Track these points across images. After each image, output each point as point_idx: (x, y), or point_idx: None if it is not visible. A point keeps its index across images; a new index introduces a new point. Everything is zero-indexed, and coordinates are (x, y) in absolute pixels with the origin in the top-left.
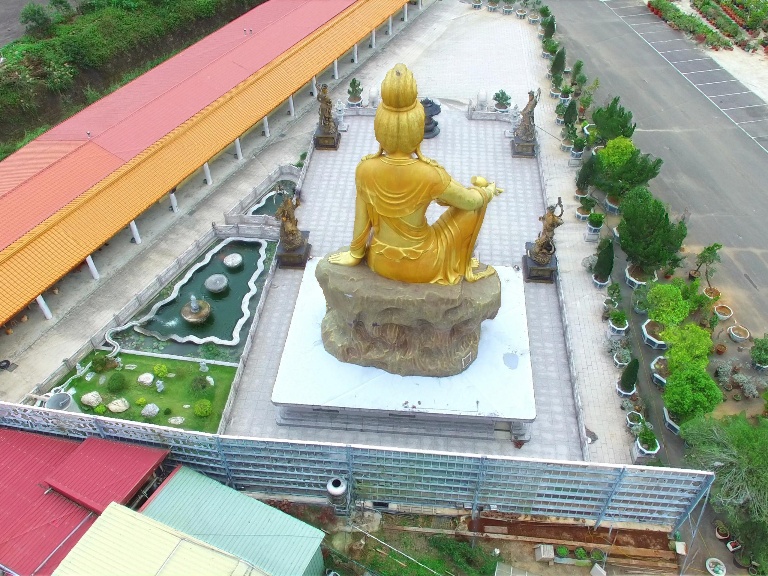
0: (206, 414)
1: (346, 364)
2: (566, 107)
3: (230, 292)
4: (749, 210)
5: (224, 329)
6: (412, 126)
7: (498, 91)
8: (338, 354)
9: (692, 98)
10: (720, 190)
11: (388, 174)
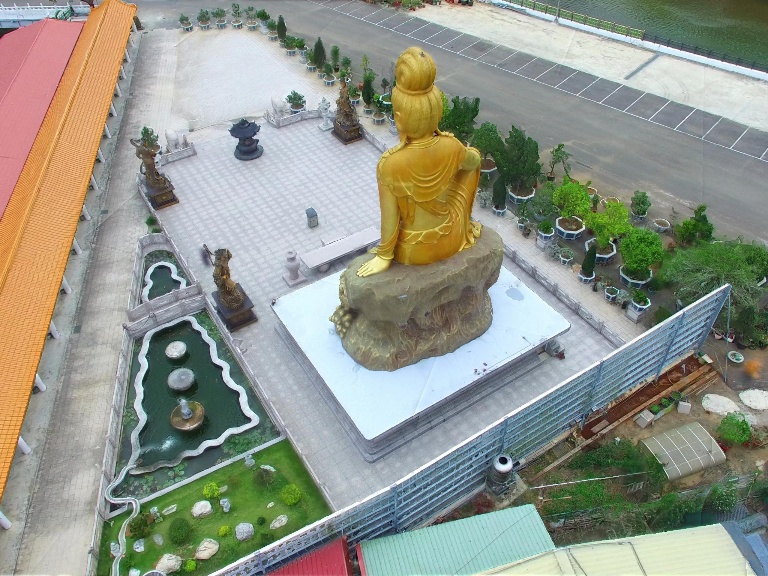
0: (299, 498)
1: (399, 371)
2: (354, 88)
3: (197, 382)
4: (539, 117)
5: (231, 417)
6: (440, 103)
7: (290, 93)
8: (388, 366)
9: (430, 51)
10: (509, 111)
11: (423, 159)
